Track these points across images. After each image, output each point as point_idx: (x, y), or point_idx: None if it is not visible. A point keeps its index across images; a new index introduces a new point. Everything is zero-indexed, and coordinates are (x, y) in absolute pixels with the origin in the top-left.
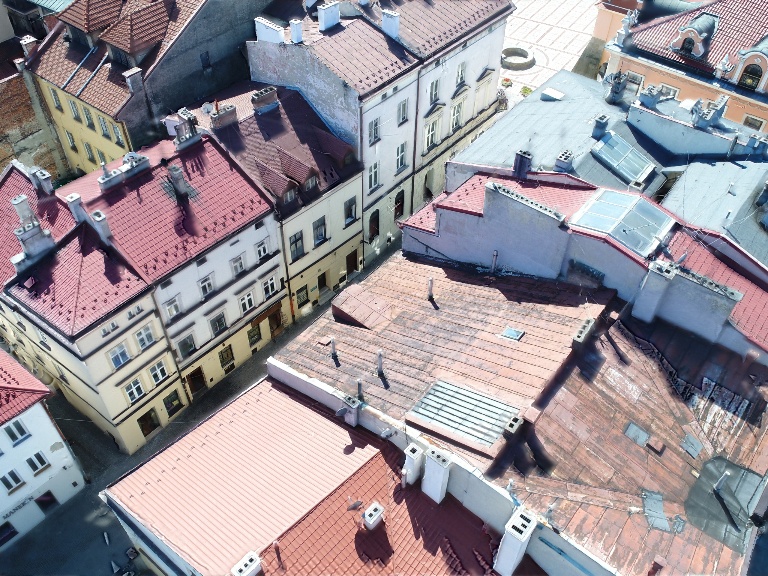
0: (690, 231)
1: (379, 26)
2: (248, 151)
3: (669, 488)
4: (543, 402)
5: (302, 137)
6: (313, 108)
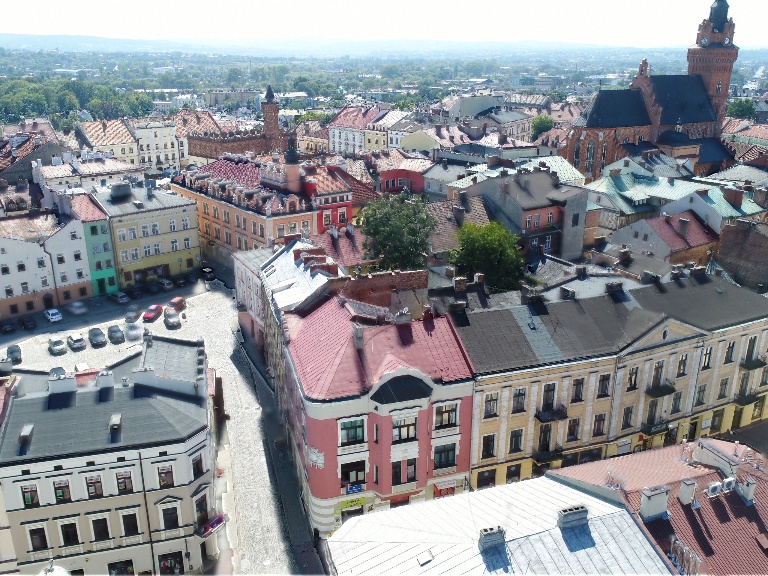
0: (88, 195)
1: (73, 165)
2: (7, 194)
3: (26, 236)
4: (8, 219)
5: (31, 194)
6: (41, 188)
